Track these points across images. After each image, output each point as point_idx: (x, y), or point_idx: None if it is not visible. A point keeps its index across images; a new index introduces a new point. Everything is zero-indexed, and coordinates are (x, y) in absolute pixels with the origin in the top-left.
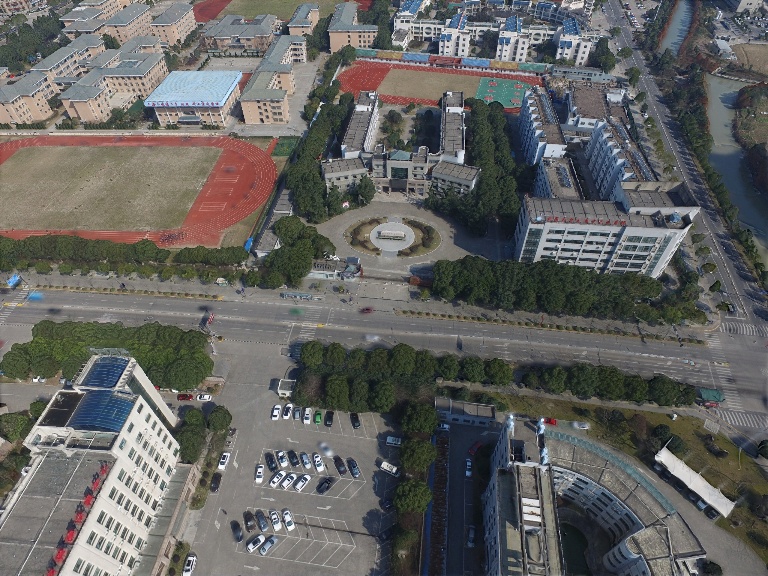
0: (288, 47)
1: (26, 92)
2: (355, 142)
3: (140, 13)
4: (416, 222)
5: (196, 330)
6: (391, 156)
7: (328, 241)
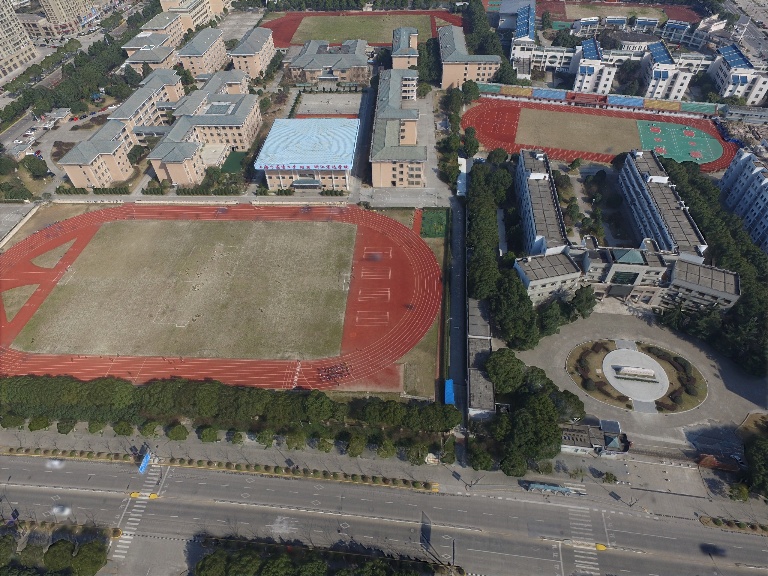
0: (400, 84)
1: (107, 150)
2: (551, 230)
3: (214, 40)
4: (660, 350)
5: (419, 553)
6: (618, 257)
7: (580, 401)
